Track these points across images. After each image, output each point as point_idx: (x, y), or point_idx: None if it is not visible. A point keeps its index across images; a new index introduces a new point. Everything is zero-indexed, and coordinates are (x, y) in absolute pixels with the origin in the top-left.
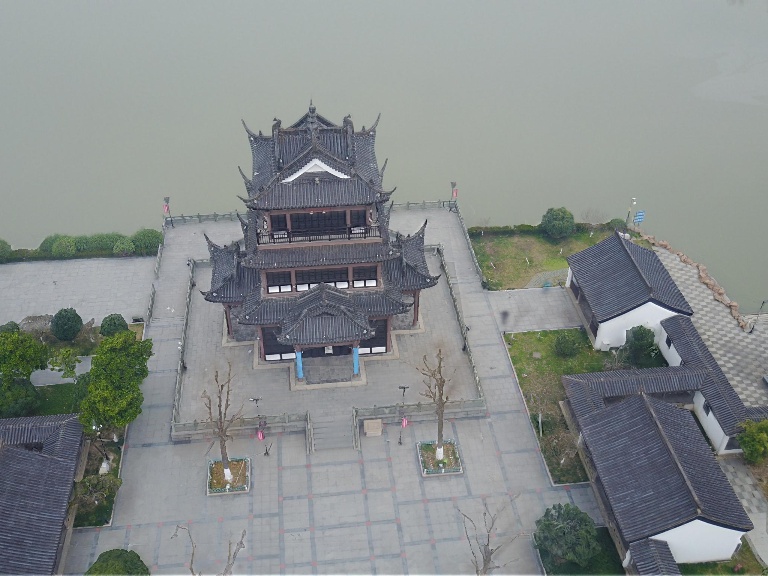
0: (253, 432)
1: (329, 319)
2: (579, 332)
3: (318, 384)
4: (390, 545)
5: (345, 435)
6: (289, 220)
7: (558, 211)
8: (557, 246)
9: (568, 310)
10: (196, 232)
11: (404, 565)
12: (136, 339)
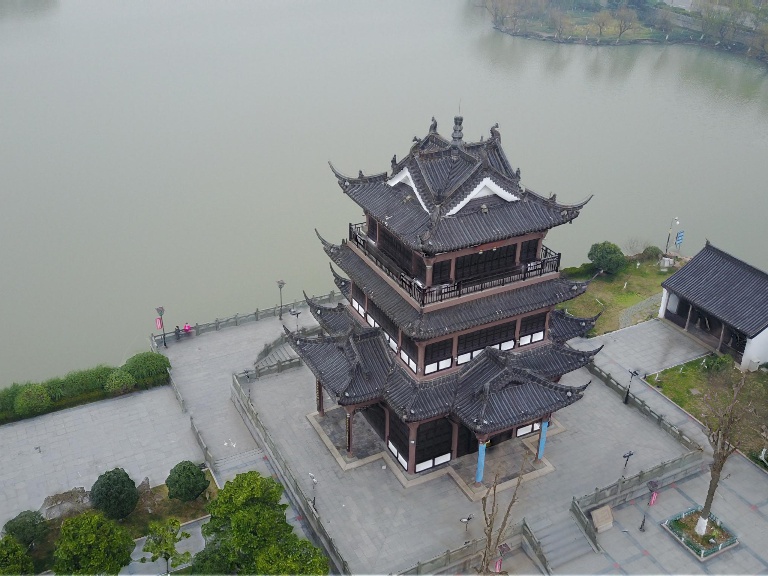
0: (460, 570)
1: (516, 390)
2: (713, 359)
3: (500, 484)
4: None
5: (576, 538)
6: (453, 267)
7: (607, 244)
8: (614, 283)
9: (682, 340)
10: (200, 347)
11: None
12: (211, 493)
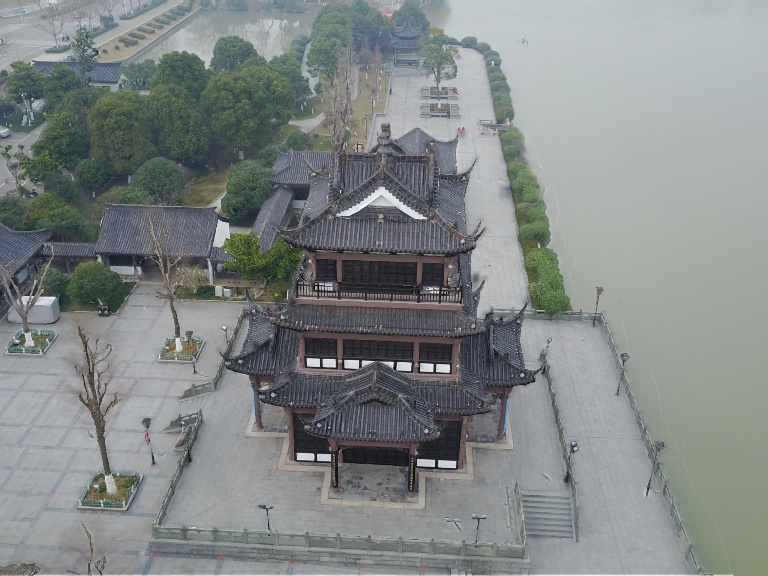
0: None
1: None
2: None
3: None
4: (35, 438)
5: None
6: None
7: None
8: None
9: None
10: (586, 340)
11: (7, 444)
12: None
